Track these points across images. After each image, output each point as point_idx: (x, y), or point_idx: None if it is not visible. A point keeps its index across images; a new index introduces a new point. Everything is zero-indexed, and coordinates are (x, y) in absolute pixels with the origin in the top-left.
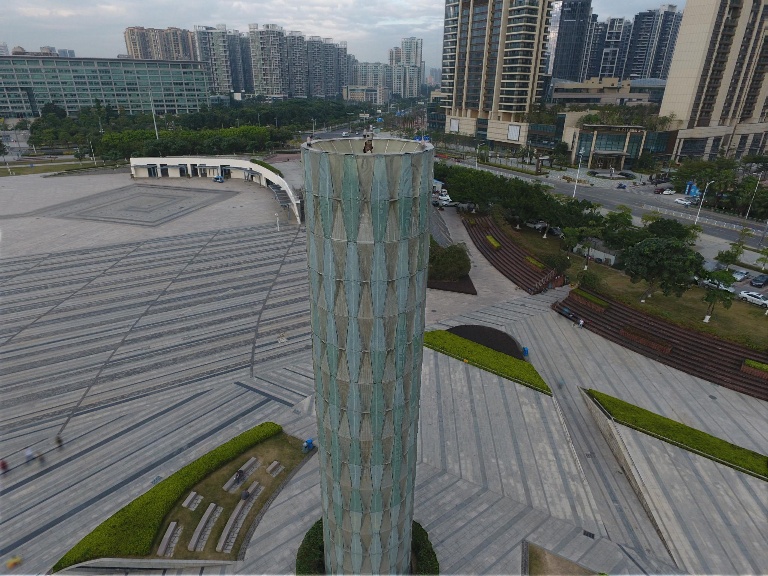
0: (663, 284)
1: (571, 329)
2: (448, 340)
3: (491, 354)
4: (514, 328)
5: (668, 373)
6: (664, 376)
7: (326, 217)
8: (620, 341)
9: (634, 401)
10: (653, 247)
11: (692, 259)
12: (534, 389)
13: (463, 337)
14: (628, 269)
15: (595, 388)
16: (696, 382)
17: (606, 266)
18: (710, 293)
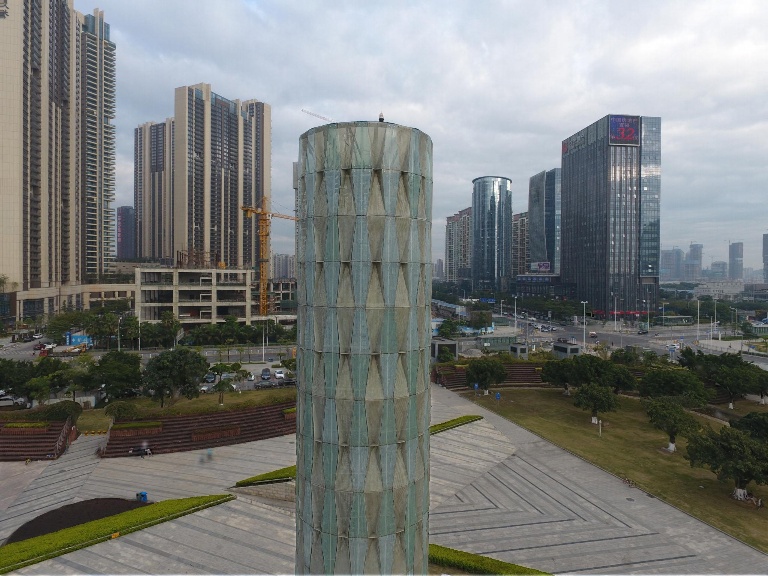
0: (184, 390)
1: (146, 461)
2: (45, 541)
3: (121, 517)
4: (91, 492)
5: (254, 446)
6: (255, 448)
7: (410, 196)
8: (198, 446)
9: (267, 471)
10: (170, 358)
11: (204, 358)
12: (216, 505)
13: (50, 532)
14: (154, 386)
15: (235, 482)
16: (273, 441)
17: (88, 410)
18: (220, 383)
